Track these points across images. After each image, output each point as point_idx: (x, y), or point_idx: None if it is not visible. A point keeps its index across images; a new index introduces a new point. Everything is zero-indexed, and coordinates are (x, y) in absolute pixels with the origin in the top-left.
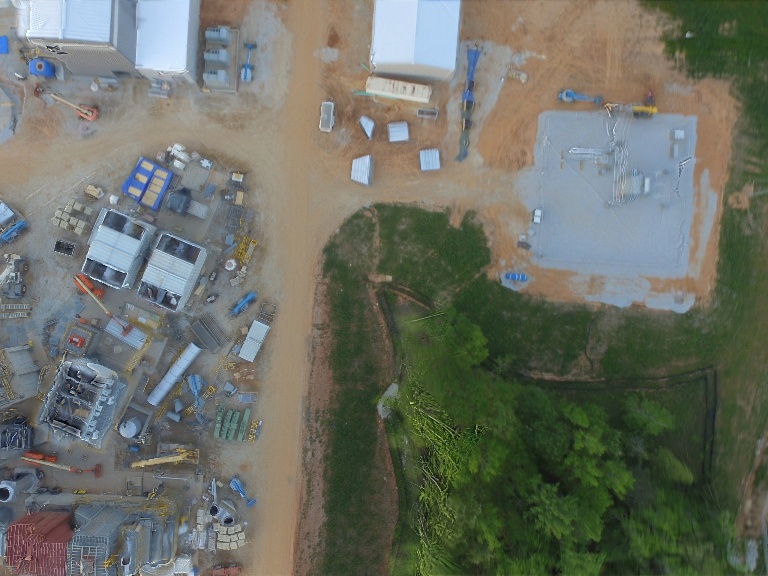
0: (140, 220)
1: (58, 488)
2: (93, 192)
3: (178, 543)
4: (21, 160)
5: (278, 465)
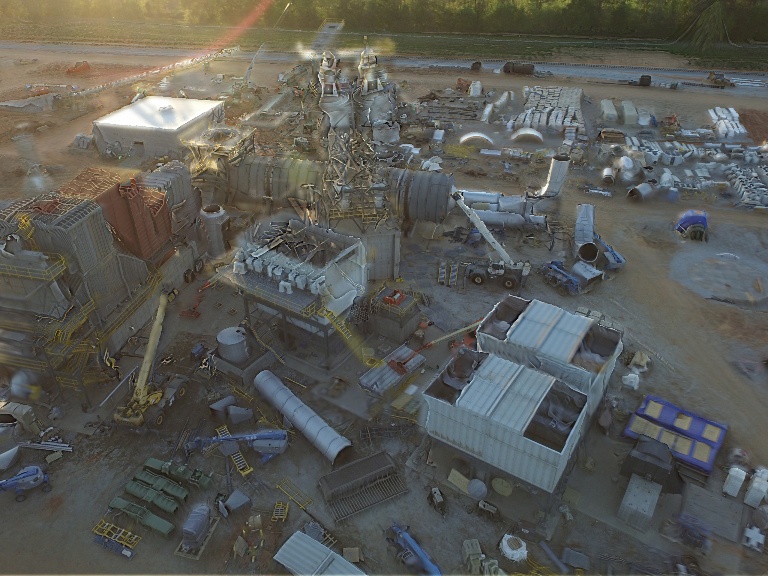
0: (604, 394)
1: (193, 278)
2: (639, 358)
3: (1, 371)
4: (669, 300)
5: (7, 575)
